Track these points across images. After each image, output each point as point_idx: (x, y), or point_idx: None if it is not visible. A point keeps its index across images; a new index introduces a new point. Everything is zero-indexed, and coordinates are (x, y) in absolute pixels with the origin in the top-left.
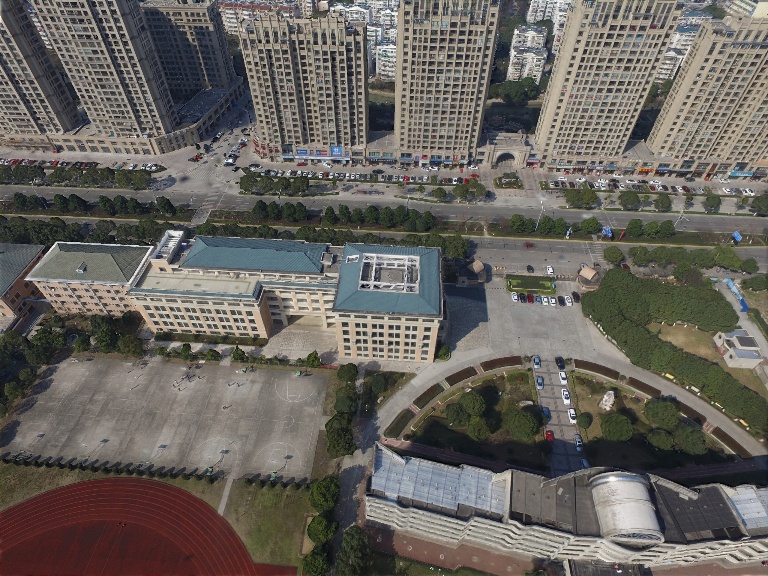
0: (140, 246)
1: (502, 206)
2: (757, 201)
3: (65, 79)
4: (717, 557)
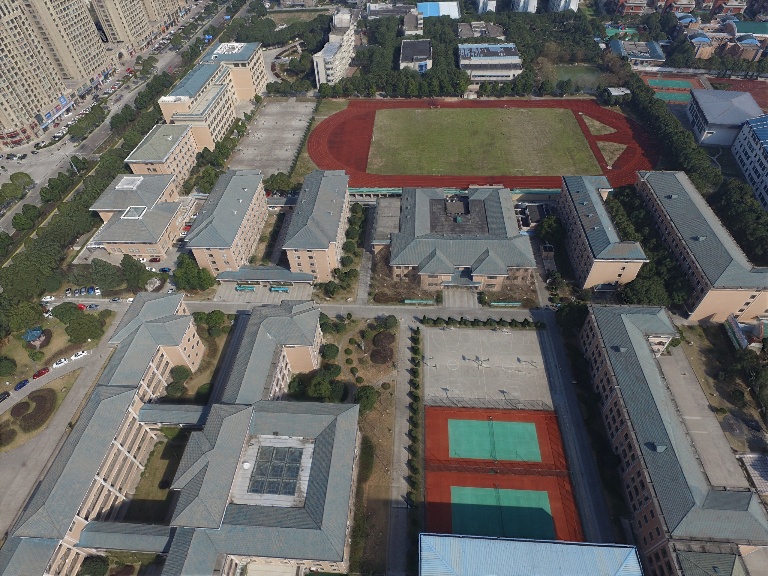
0: (152, 129)
1: (164, 65)
2: (207, 11)
3: None
4: None
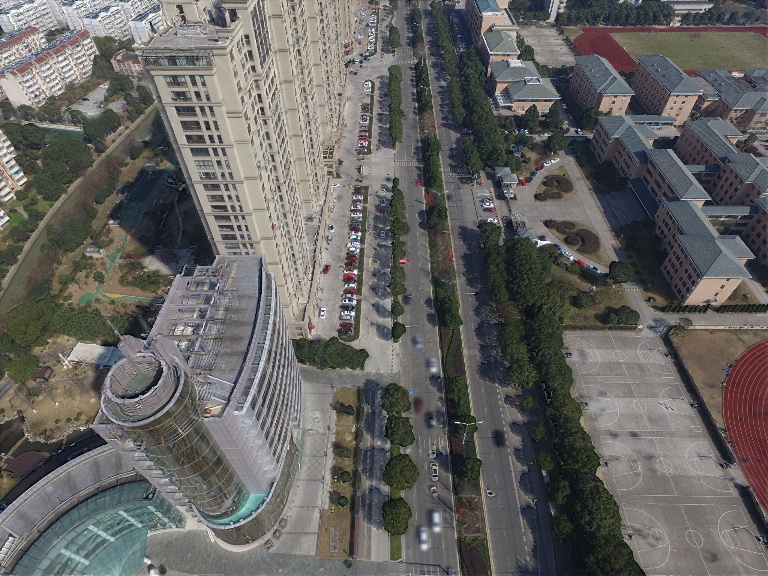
0: None
1: None
2: None
3: (161, 168)
4: None
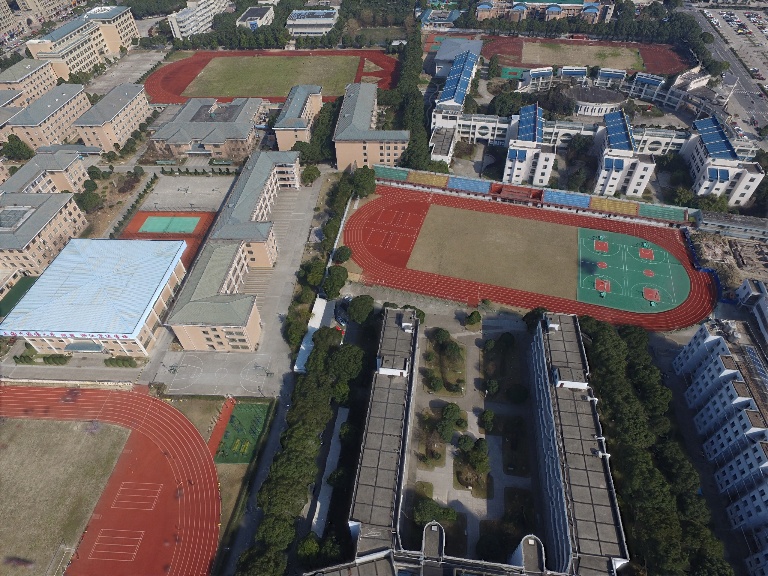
0: None
1: None
2: None
3: None
4: (222, 10)
